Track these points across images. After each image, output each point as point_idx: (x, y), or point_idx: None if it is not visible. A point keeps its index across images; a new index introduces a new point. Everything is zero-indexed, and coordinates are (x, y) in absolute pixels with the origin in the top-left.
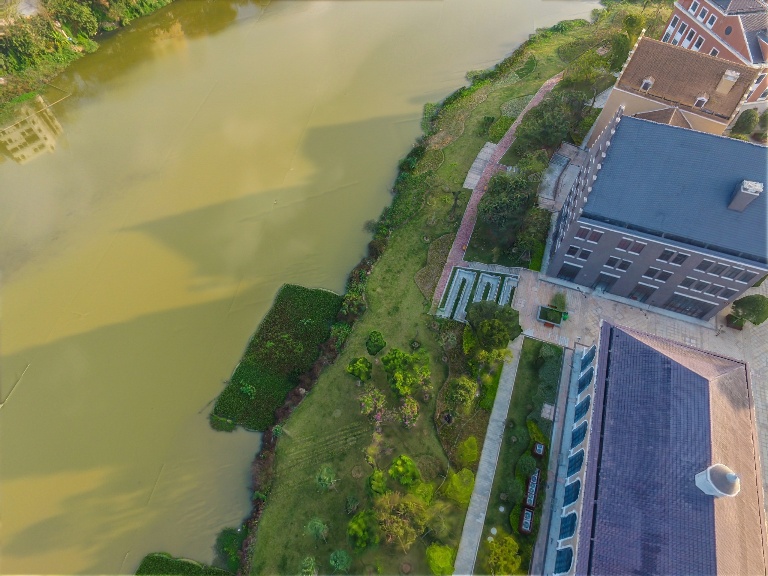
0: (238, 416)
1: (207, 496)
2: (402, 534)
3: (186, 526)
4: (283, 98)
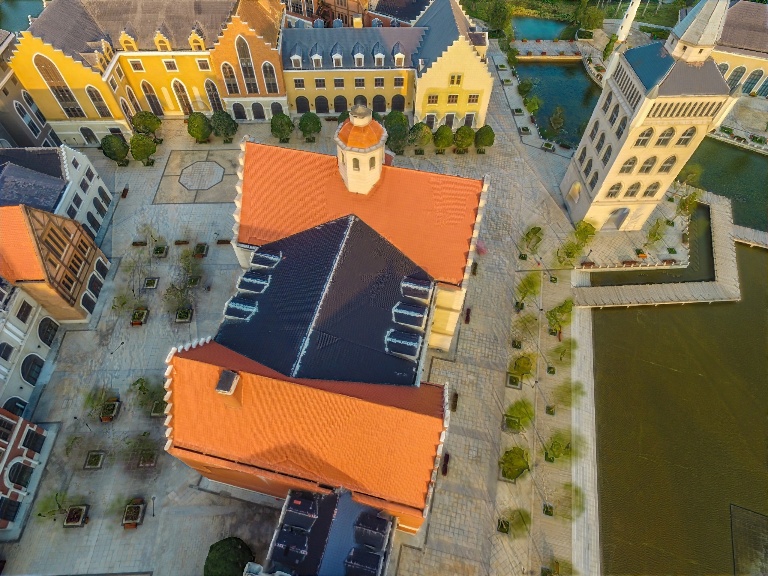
0: None
1: None
2: None
3: None
4: None
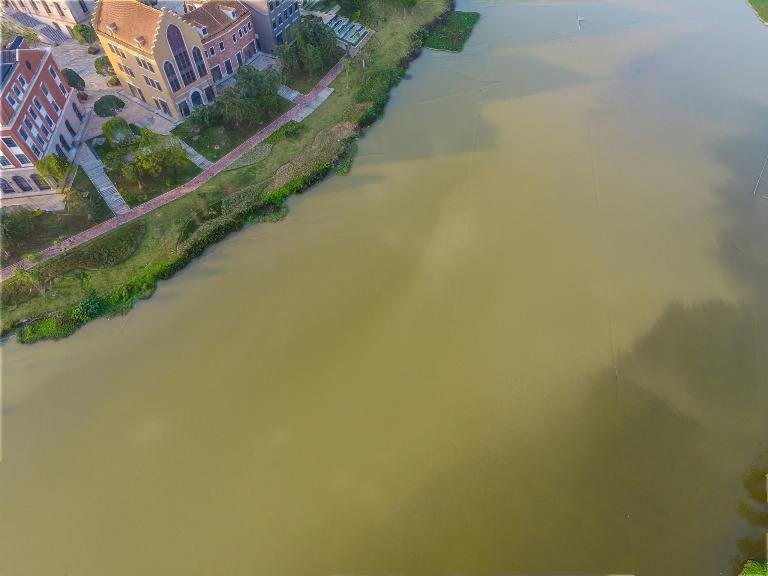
0: None
1: None
2: None
3: None
4: (509, 182)
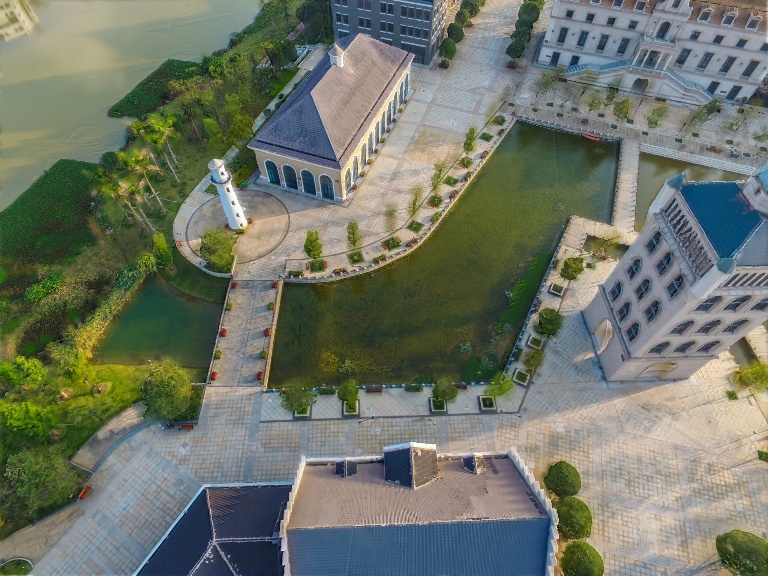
0: (125, 111)
1: (100, 140)
2: (178, 88)
3: (85, 150)
4: None
